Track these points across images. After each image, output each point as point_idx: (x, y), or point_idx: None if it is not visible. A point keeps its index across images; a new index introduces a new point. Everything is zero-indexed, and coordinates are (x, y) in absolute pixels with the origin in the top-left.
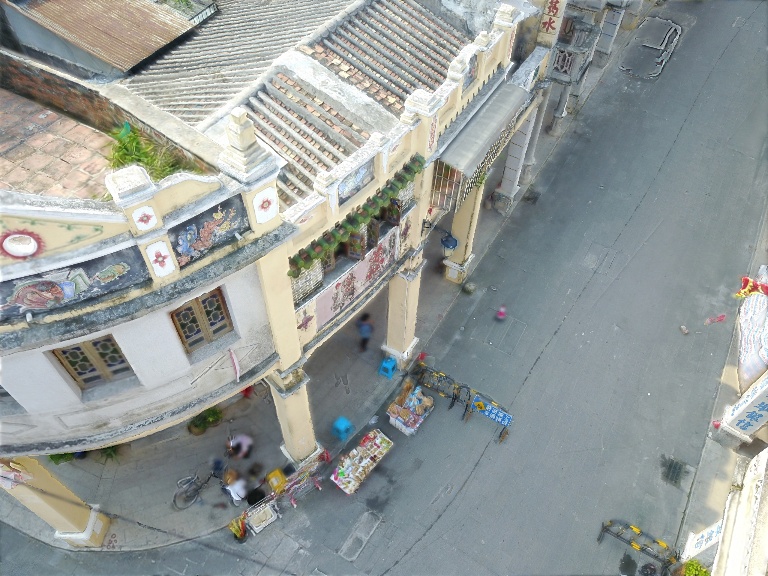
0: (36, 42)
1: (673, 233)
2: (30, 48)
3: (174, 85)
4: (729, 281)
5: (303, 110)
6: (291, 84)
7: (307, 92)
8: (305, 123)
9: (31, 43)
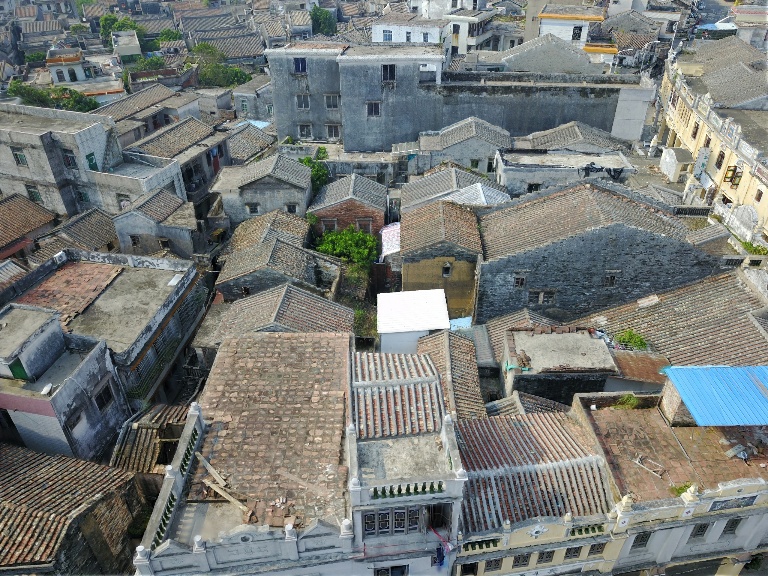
0: (617, 389)
1: None
2: None
3: None
4: None
5: None
6: None
7: None
8: None
9: None
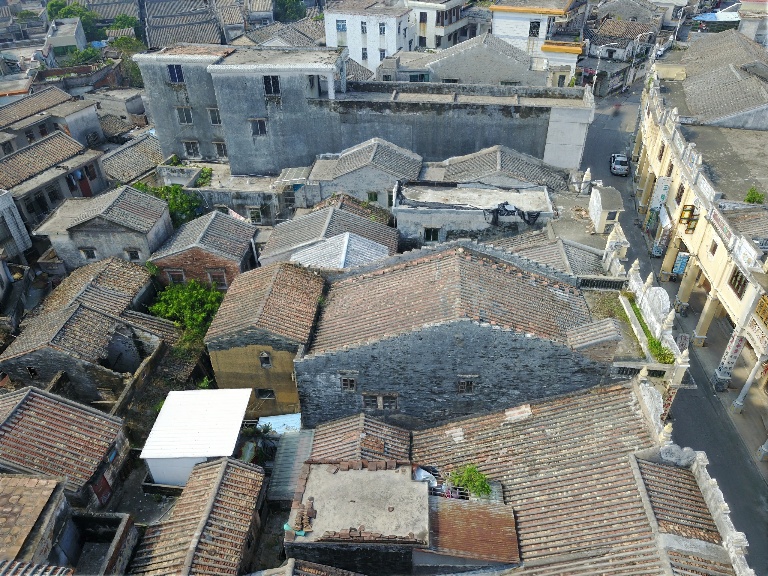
0: (431, 562)
1: (714, 472)
2: (423, 566)
3: (584, 569)
4: (761, 491)
5: (693, 567)
6: (676, 555)
7: (684, 555)
8: (696, 573)
9: (423, 563)
